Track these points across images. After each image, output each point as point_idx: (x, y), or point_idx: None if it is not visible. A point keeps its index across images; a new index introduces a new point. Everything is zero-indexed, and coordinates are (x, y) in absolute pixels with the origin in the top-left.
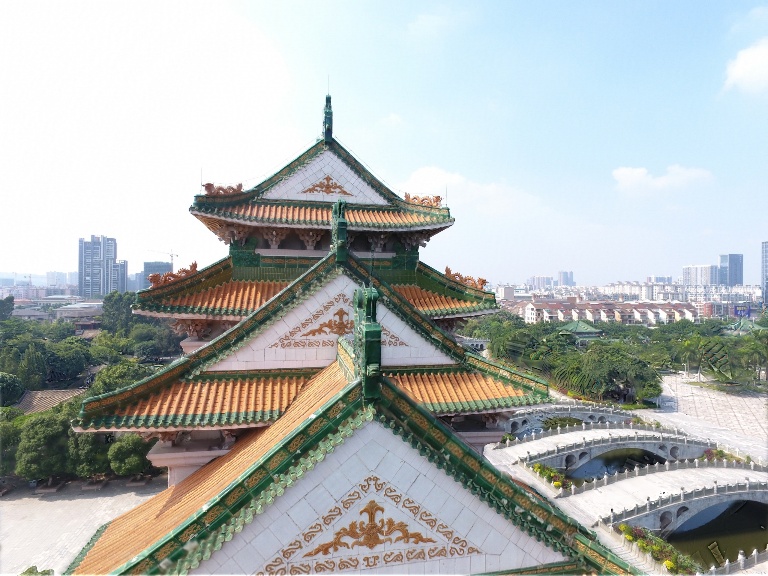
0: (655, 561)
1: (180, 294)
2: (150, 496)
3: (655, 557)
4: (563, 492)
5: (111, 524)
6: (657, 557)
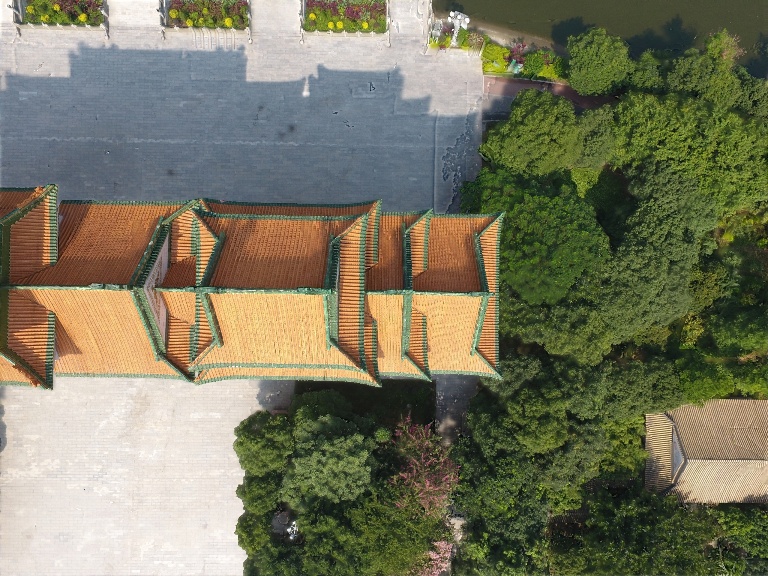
0: (224, 29)
1: (368, 370)
2: (7, 436)
3: (213, 20)
4: (105, 26)
5: None
6: (212, 18)
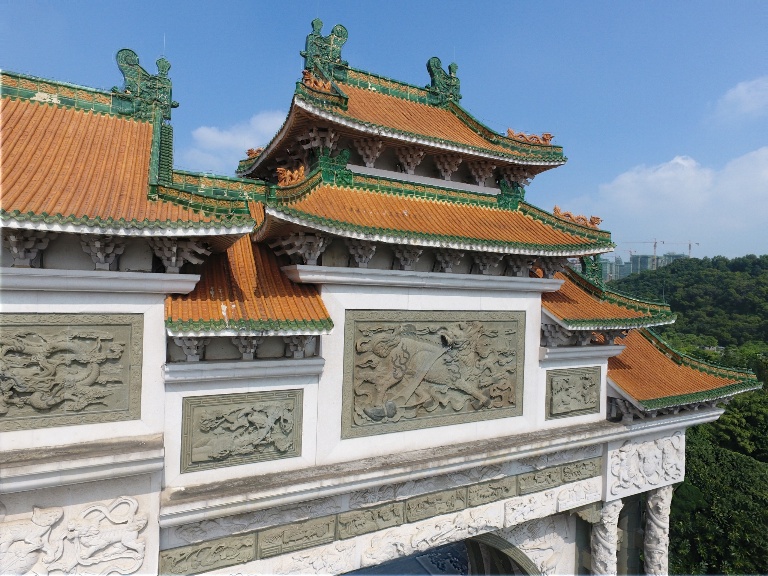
0: None
1: None
2: None
3: None
4: None
5: (642, 399)
6: None
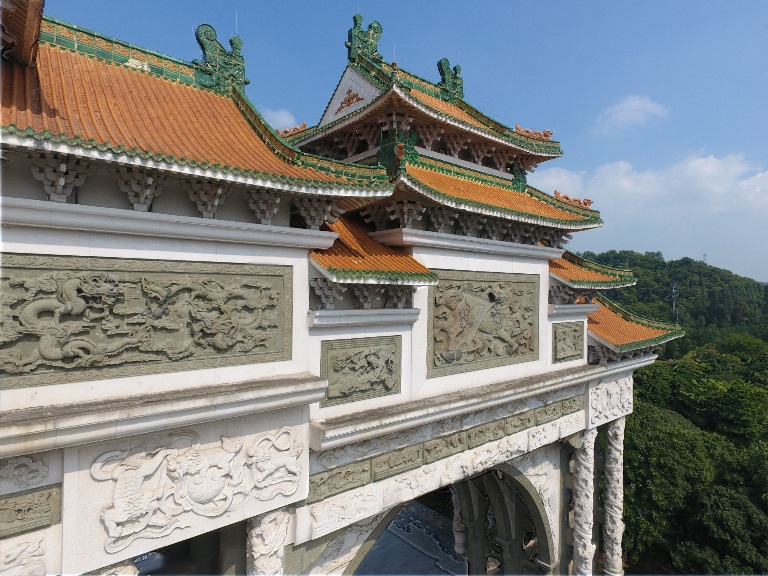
0: None
1: None
2: None
3: None
4: None
5: (616, 344)
6: None
